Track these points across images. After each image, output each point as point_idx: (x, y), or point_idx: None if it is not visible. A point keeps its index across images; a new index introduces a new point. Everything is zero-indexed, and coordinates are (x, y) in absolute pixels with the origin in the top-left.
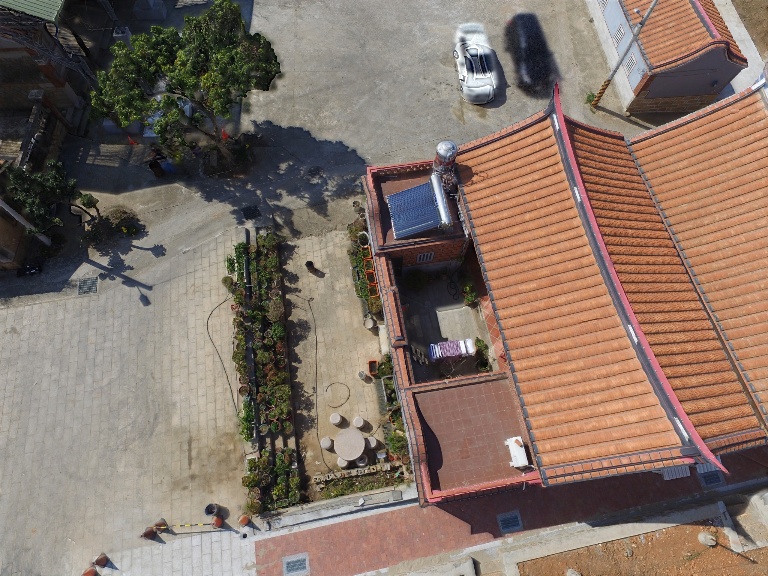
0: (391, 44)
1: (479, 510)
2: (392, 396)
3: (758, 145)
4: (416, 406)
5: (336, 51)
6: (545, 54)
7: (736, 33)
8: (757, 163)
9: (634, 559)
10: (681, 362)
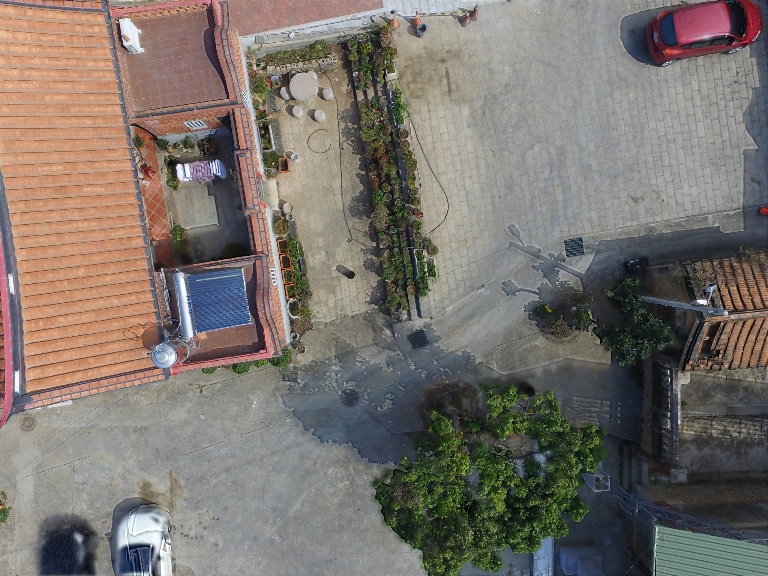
0: None
1: None
2: (264, 131)
3: None
4: None
5: None
6: None
7: None
8: None
9: None
10: None
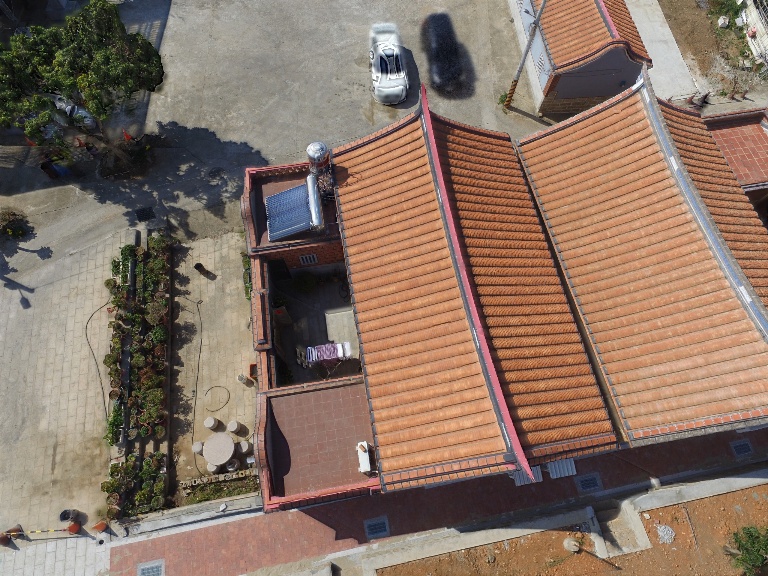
0: (306, 44)
1: (346, 515)
2: None
3: (637, 146)
4: (269, 411)
5: (250, 51)
6: (462, 54)
7: (660, 33)
8: (635, 164)
9: (496, 565)
10: (531, 366)
